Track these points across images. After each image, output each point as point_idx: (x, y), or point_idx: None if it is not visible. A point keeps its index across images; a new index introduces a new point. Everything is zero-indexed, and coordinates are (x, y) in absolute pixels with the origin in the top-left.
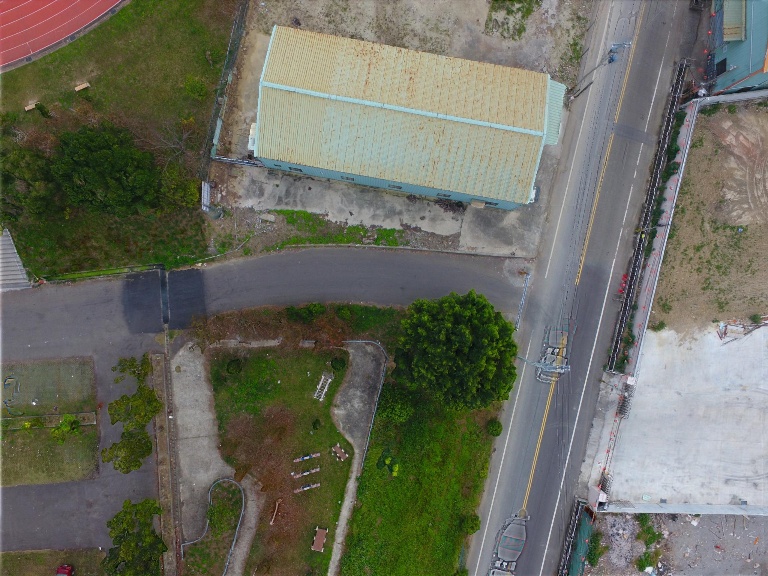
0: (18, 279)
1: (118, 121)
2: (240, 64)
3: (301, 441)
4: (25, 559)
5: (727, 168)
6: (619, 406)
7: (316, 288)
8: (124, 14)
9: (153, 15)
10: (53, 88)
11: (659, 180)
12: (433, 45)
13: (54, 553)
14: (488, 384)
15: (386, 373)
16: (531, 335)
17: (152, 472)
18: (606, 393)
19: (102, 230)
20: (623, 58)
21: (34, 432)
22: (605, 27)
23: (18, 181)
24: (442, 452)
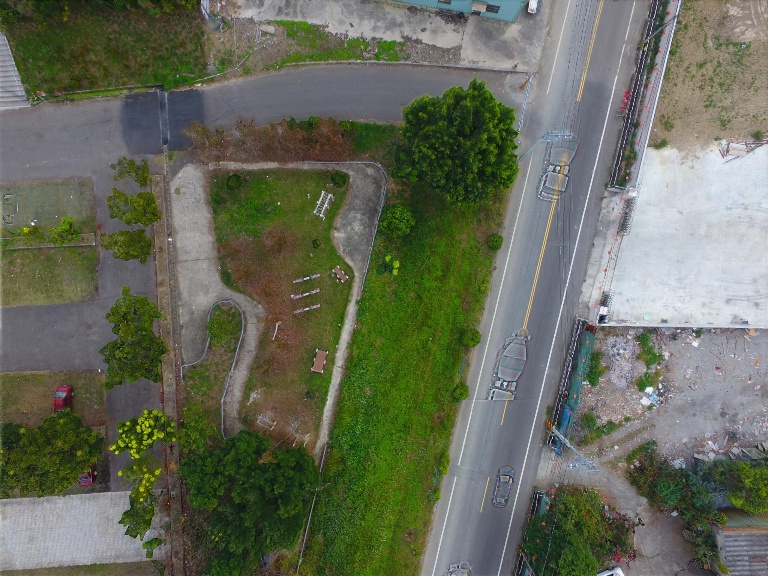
0: (16, 96)
1: None
2: None
3: (301, 263)
4: (24, 380)
5: None
6: (620, 225)
7: (316, 106)
8: None
9: None
10: None
11: None
12: None
13: (53, 374)
14: (489, 168)
15: (386, 195)
16: (532, 152)
17: (151, 294)
18: (607, 212)
19: (101, 41)
20: None
21: (33, 253)
22: None
23: None
24: (442, 266)
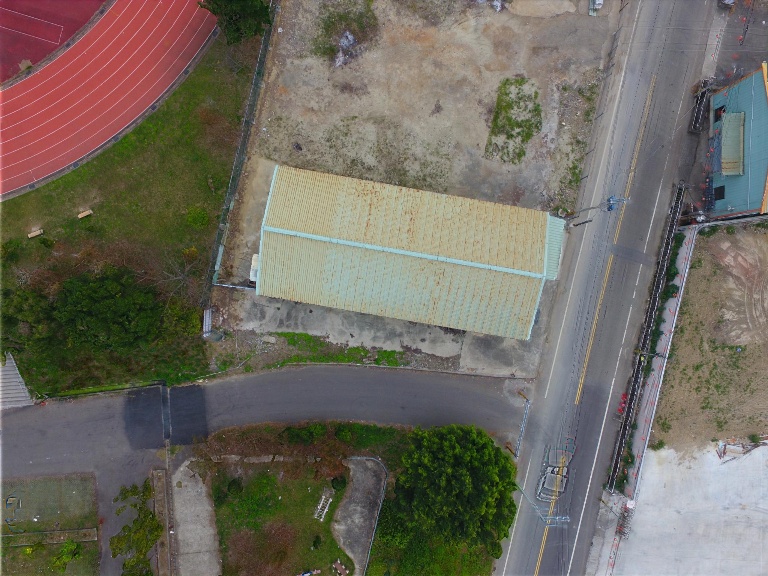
0: (20, 397)
1: (120, 247)
2: (242, 189)
3: (302, 557)
4: None
5: (726, 288)
6: (619, 525)
7: (317, 406)
8: (127, 142)
9: (156, 142)
10: (56, 215)
11: (658, 301)
12: (433, 169)
13: None
14: (488, 525)
15: (386, 489)
16: (531, 454)
17: None
18: (606, 511)
19: (104, 352)
20: (622, 181)
21: None
22: (604, 150)
23: (21, 323)
24: (442, 573)
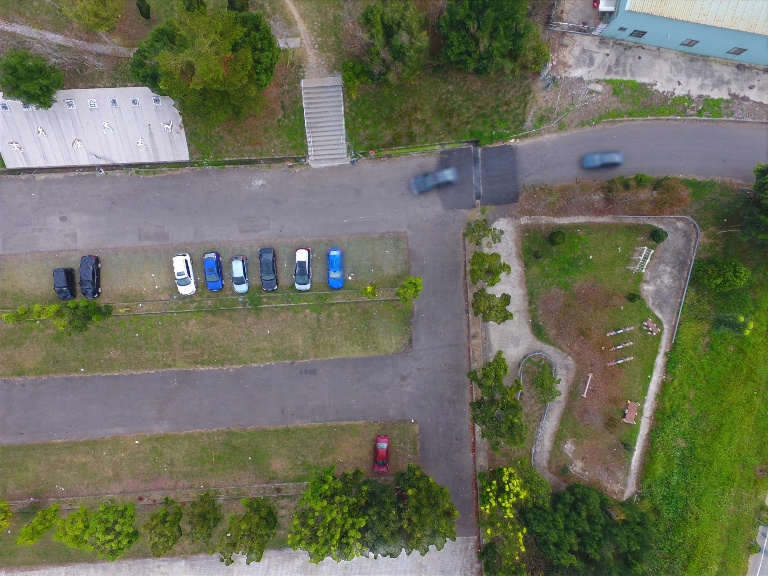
0: (337, 154)
1: None
2: None
3: (611, 316)
4: (341, 430)
5: None
6: None
7: (633, 162)
8: None
9: None
10: None
11: None
12: None
13: (368, 425)
14: None
15: (697, 248)
16: None
17: (463, 346)
18: None
19: (431, 101)
20: None
21: (350, 306)
22: None
23: (402, 32)
24: (767, 321)
